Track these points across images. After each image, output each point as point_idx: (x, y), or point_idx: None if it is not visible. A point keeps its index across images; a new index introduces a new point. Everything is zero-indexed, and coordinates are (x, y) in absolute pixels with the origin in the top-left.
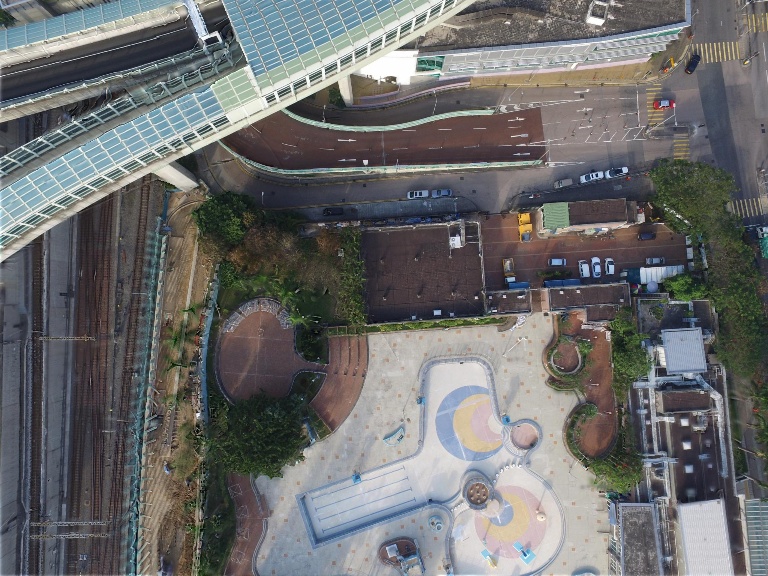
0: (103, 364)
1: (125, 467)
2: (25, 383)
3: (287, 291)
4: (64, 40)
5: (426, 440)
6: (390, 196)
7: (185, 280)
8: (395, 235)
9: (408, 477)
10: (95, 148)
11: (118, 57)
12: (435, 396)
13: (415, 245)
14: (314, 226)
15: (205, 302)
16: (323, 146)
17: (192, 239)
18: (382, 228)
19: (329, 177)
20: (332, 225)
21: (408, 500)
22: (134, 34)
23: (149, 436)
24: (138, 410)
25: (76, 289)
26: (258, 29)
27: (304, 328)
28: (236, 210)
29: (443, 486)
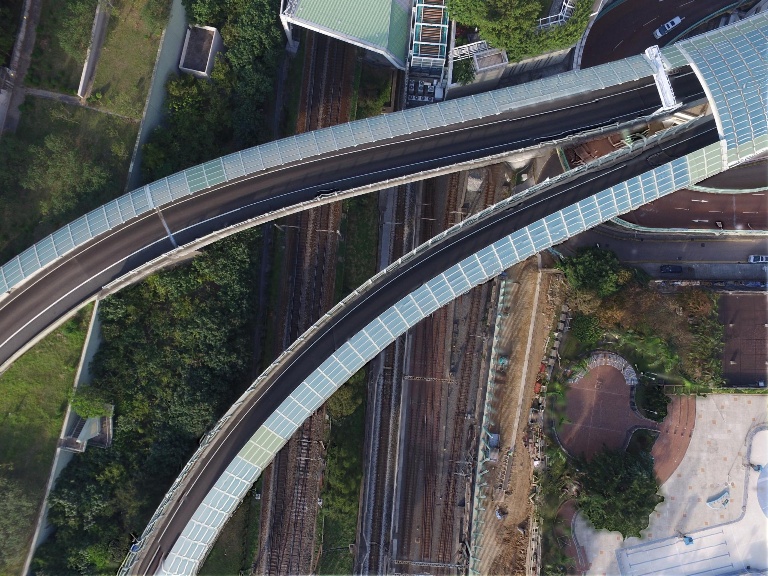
0: (437, 403)
1: (455, 508)
2: (374, 418)
3: (673, 354)
4: (512, 99)
5: (747, 506)
6: (729, 258)
7: (524, 327)
8: (745, 299)
9: (726, 542)
10: (573, 212)
11: (559, 118)
12: (757, 462)
13: (765, 311)
14: (649, 282)
15: (546, 350)
16: (677, 205)
17: (532, 286)
18: (734, 292)
19: (668, 234)
20: (668, 282)
21: (725, 565)
22: (575, 96)
23: (482, 479)
24: (473, 452)
25: (414, 326)
26: (736, 105)
27: (641, 384)
28: (610, 267)
29: (762, 554)
